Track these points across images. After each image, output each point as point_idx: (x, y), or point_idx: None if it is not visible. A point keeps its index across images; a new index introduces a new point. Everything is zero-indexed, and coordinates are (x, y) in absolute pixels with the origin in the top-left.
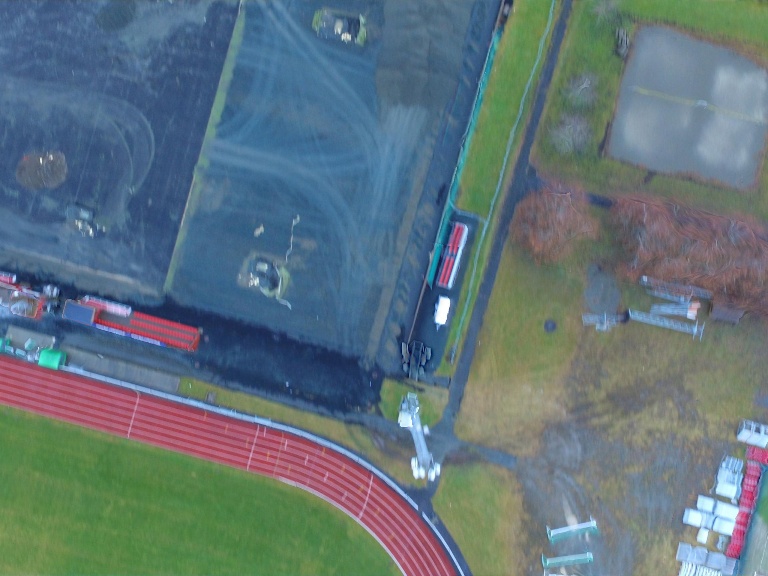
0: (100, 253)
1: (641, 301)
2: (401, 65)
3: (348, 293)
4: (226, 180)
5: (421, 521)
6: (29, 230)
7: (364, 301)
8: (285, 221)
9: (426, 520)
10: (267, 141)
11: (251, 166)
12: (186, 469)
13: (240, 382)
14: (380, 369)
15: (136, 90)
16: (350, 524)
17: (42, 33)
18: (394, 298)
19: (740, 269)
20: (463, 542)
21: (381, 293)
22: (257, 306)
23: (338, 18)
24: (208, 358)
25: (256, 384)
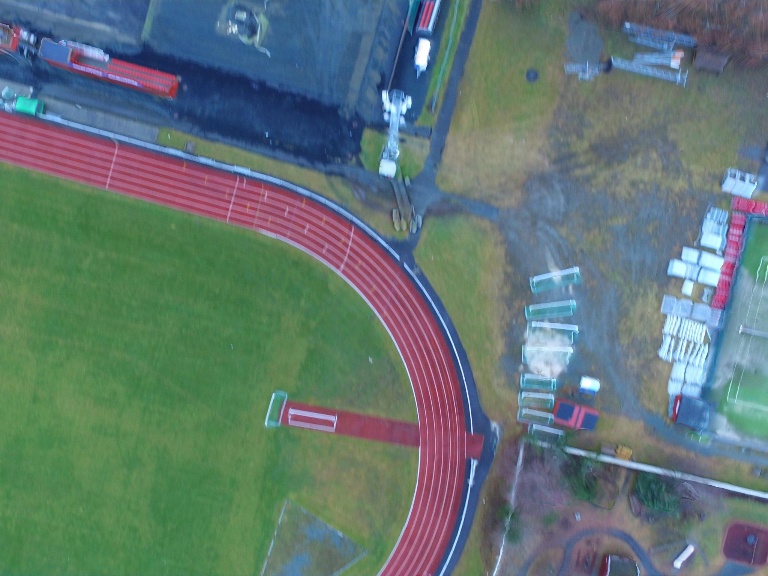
0: (77, 1)
1: (624, 50)
2: None
3: (327, 40)
4: None
5: (403, 273)
6: None
7: (344, 49)
8: None
9: (408, 270)
10: None
11: None
12: (165, 221)
13: (219, 133)
14: (360, 118)
15: None
16: (331, 277)
17: None
18: (374, 45)
19: None
20: (445, 295)
21: (361, 41)
22: (236, 54)
23: None
24: (187, 108)
25: (235, 135)
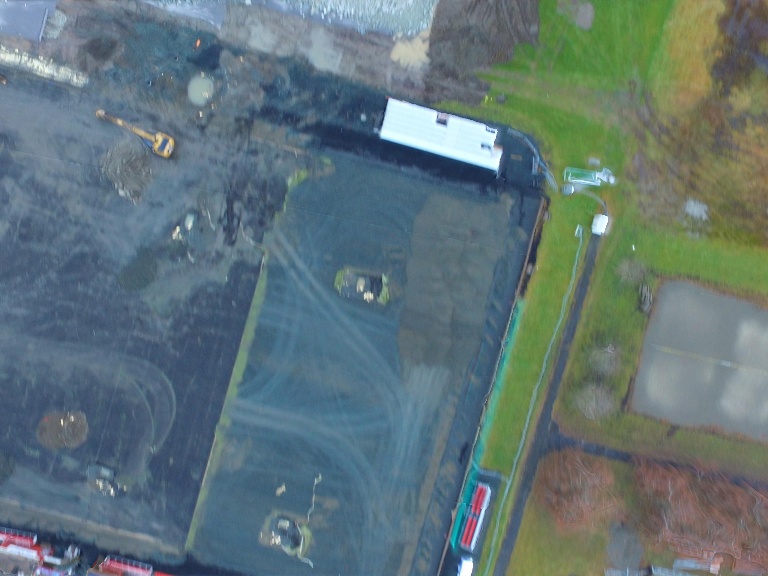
0: (121, 512)
1: (664, 555)
2: (424, 331)
3: (370, 551)
4: (248, 439)
5: None
6: (50, 489)
7: (386, 559)
8: (307, 480)
9: None
10: (289, 400)
11: (273, 425)
12: None
13: None
14: None
15: (157, 350)
16: None
17: (63, 293)
18: (416, 556)
19: (766, 551)
20: None
21: (403, 551)
22: (279, 564)
23: (360, 276)
24: None
25: None
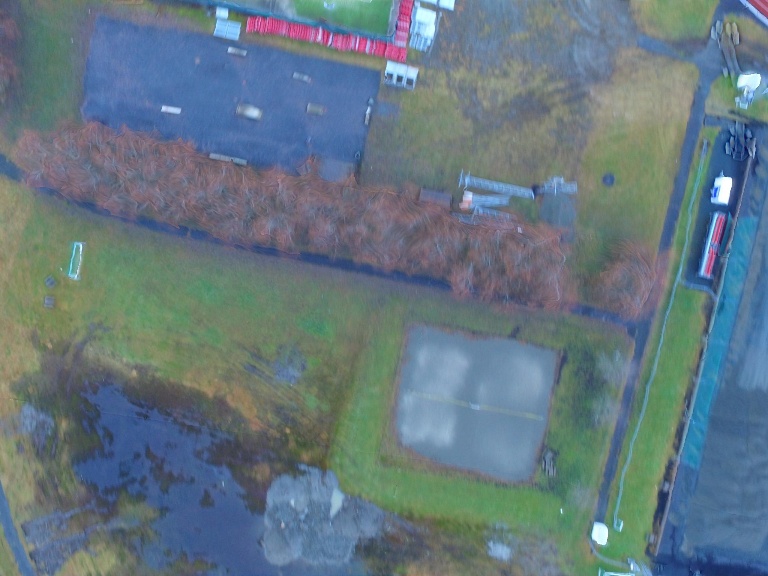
0: None
1: (519, 208)
2: None
3: None
4: None
5: None
6: None
7: None
8: None
9: None
10: None
11: None
12: None
13: None
14: None
15: None
16: None
17: None
18: (764, 202)
19: None
20: None
21: None
22: None
23: None
24: None
25: None
